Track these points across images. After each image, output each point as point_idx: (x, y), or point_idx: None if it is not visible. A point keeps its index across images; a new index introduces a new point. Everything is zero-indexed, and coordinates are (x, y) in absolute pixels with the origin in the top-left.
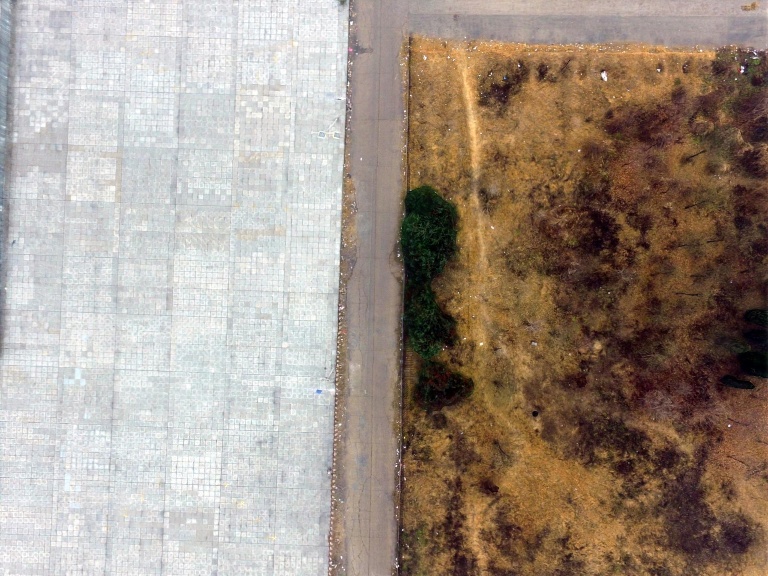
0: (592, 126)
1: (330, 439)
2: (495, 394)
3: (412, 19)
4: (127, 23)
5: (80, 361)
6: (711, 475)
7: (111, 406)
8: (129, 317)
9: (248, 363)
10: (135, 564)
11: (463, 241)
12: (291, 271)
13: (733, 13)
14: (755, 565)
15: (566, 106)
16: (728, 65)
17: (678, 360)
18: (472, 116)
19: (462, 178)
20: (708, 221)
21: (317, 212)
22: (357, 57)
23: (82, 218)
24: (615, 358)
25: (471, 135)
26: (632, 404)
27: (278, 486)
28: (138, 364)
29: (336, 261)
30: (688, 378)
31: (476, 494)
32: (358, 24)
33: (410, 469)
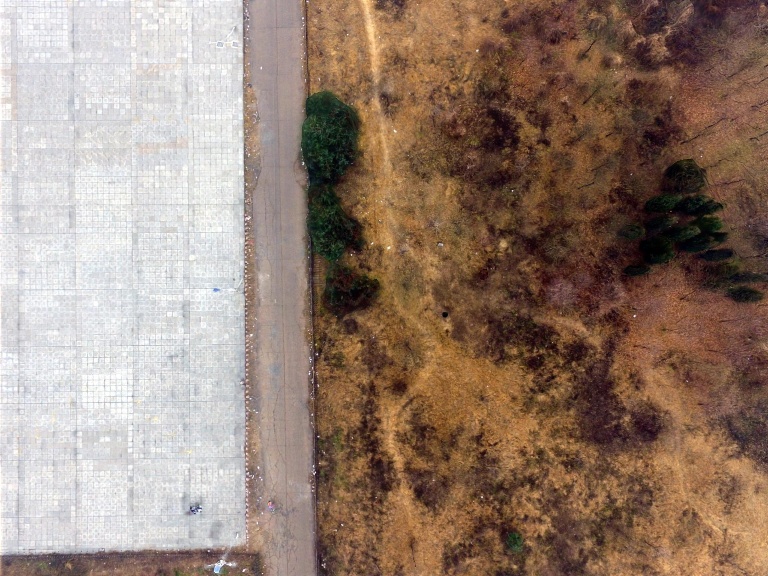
0: (489, 26)
1: (242, 350)
2: (404, 297)
3: None
4: None
5: None
6: (619, 365)
7: (17, 327)
8: (31, 236)
9: (155, 278)
10: (49, 485)
11: (366, 146)
12: (195, 183)
13: None
14: (665, 451)
15: (463, 7)
16: None
17: (582, 254)
18: (370, 20)
19: (363, 83)
20: (606, 115)
21: (219, 123)
22: None
23: None
24: (521, 255)
25: (370, 39)
26: (539, 300)
27: (191, 400)
28: (43, 284)
29: (240, 171)
30: (593, 271)
31: (389, 397)
32: None
33: (323, 375)
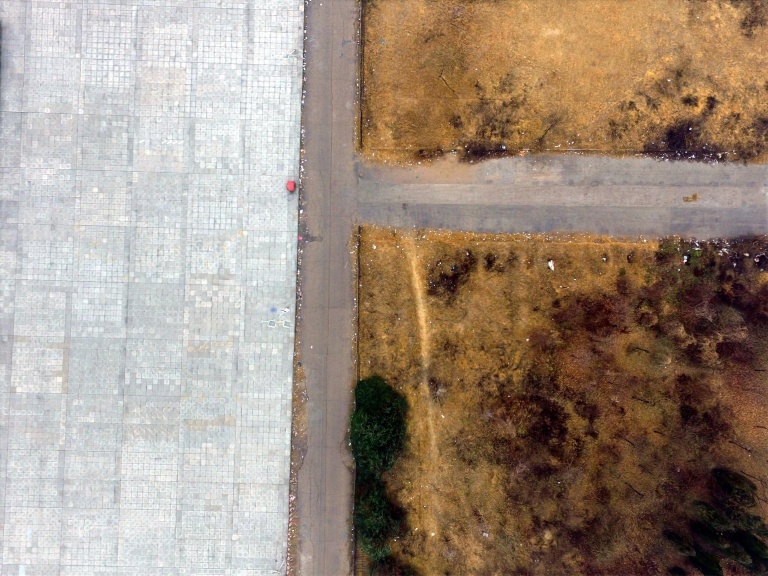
0: (540, 315)
1: None
2: None
3: (361, 208)
4: (75, 213)
5: (24, 557)
6: None
7: None
8: (75, 511)
9: (197, 556)
10: None
11: (414, 430)
12: (241, 462)
13: (675, 204)
14: None
15: (514, 295)
16: (671, 258)
17: (628, 550)
18: (422, 305)
19: (412, 367)
20: (655, 410)
21: (267, 402)
22: (307, 245)
23: (28, 410)
24: (566, 548)
25: (421, 324)
26: None
27: None
28: (84, 559)
29: (287, 451)
30: (638, 568)
31: None
32: (308, 212)
33: None
